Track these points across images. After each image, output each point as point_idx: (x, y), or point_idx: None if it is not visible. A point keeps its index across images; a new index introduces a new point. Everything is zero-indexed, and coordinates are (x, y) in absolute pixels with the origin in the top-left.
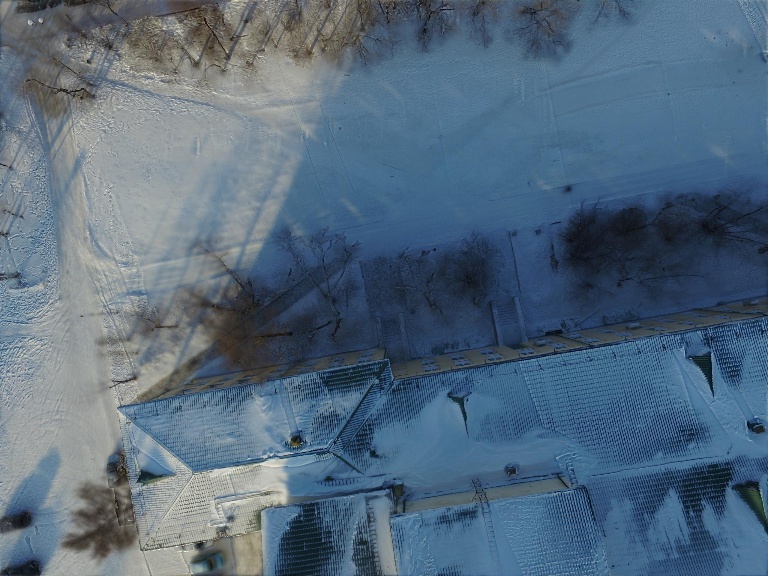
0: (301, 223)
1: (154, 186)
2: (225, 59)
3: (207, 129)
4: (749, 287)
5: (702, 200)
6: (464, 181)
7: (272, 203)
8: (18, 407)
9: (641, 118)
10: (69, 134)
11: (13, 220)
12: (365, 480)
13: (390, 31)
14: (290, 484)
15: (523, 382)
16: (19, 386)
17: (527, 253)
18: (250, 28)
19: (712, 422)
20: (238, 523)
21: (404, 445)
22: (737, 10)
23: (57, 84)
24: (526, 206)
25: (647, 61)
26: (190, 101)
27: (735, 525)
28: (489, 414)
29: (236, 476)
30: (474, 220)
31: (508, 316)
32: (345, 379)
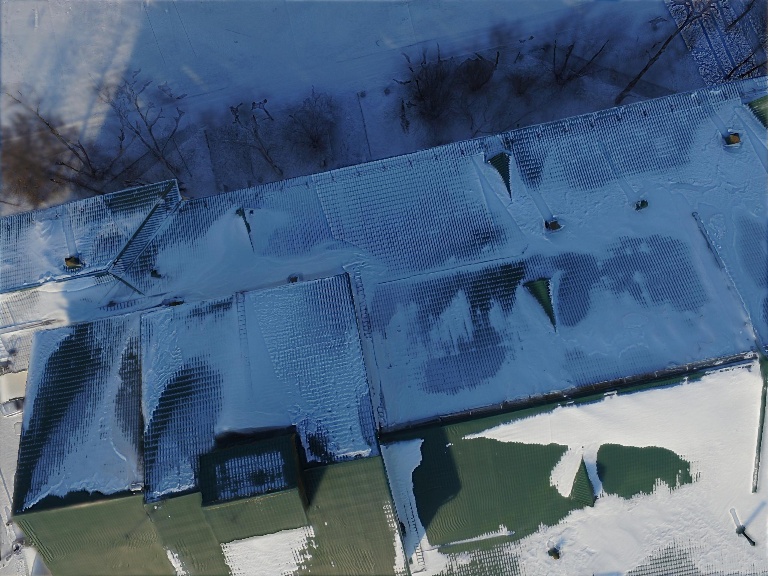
0: (144, 94)
1: None
2: None
3: (45, 0)
4: None
5: (556, 53)
6: (310, 43)
7: (113, 74)
8: None
9: None
10: None
11: None
12: (145, 300)
13: None
14: (70, 310)
15: (315, 195)
16: None
17: (376, 114)
18: None
19: (509, 224)
20: (21, 357)
21: (188, 264)
22: None
23: None
24: (374, 66)
25: None
26: None
27: (522, 320)
28: (278, 229)
29: (14, 304)
30: (321, 83)
31: None
32: (129, 201)
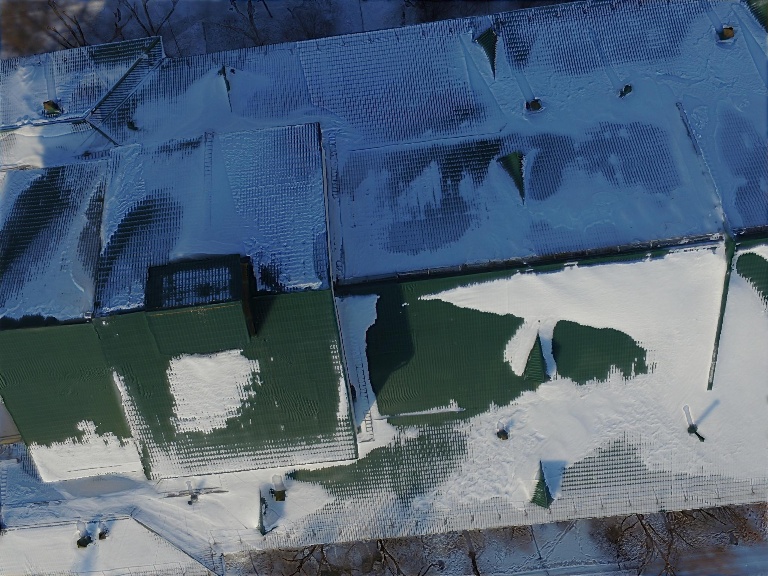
0: None
1: None
2: None
3: None
4: None
5: None
6: None
7: None
8: None
9: None
10: None
11: None
12: None
13: None
14: (45, 156)
15: (298, 62)
16: None
17: (376, 19)
18: None
19: (490, 103)
20: None
21: (165, 119)
22: None
23: None
24: None
25: None
26: None
27: (491, 192)
28: (258, 91)
29: None
30: None
31: None
32: (113, 53)
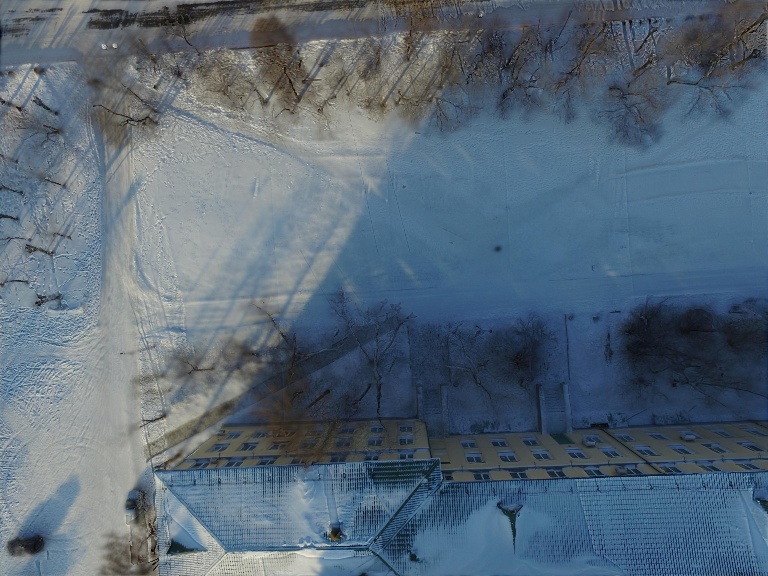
0: (352, 279)
1: (207, 223)
2: (295, 101)
3: (268, 171)
4: None
5: None
6: (525, 257)
7: (325, 255)
8: (43, 429)
9: (718, 214)
10: (127, 159)
11: (60, 240)
12: None
13: (468, 93)
14: (323, 575)
15: (578, 502)
16: (47, 408)
17: (581, 340)
18: (324, 73)
19: None
20: None
21: (446, 552)
22: None
23: (121, 107)
24: (586, 291)
25: (732, 156)
26: (254, 140)
27: None
28: (539, 531)
29: (269, 560)
30: (531, 298)
31: (554, 403)
32: (392, 474)
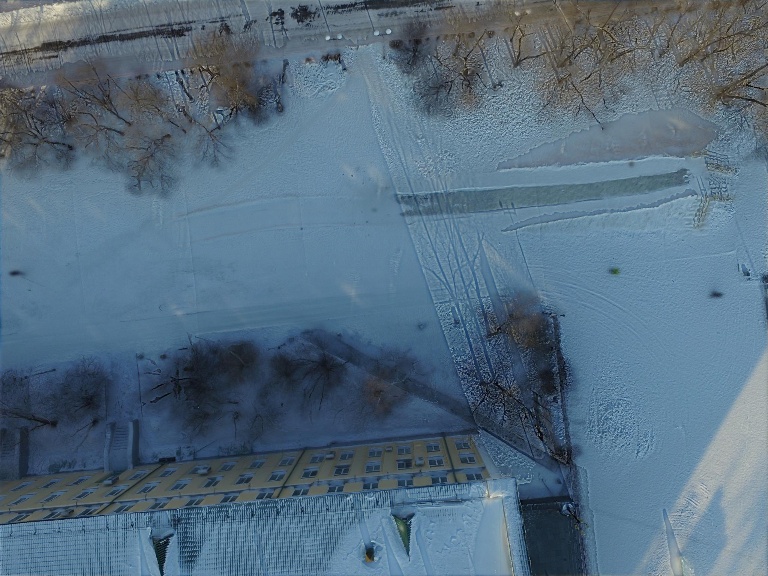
0: None
1: None
2: None
3: None
4: (364, 429)
5: (327, 337)
6: (98, 300)
7: None
8: None
9: (274, 250)
10: None
11: None
12: None
13: None
14: None
15: None
16: None
17: (151, 377)
18: None
19: None
20: None
21: None
22: (376, 149)
23: None
24: (155, 330)
25: (285, 194)
26: None
27: None
28: None
29: None
30: (104, 340)
31: (122, 440)
32: None
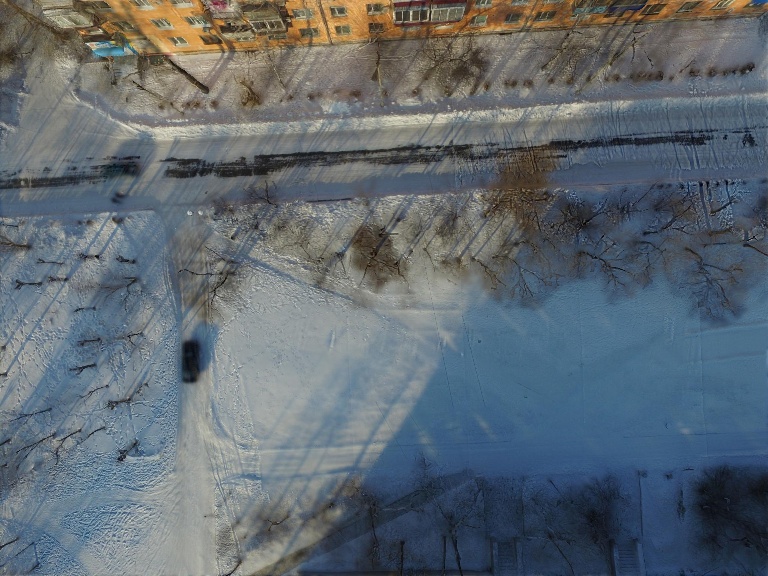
0: (427, 431)
1: (283, 373)
2: (371, 255)
3: (344, 323)
4: None
5: None
6: (599, 413)
7: (400, 407)
8: (120, 572)
9: None
10: (203, 307)
11: (138, 387)
12: None
13: (544, 250)
14: None
15: None
16: (123, 551)
17: (655, 497)
18: (401, 227)
19: None
20: None
21: None
22: None
23: None
24: (660, 448)
25: None
26: (330, 292)
27: None
28: None
29: None
30: (604, 454)
31: (628, 561)
32: None
